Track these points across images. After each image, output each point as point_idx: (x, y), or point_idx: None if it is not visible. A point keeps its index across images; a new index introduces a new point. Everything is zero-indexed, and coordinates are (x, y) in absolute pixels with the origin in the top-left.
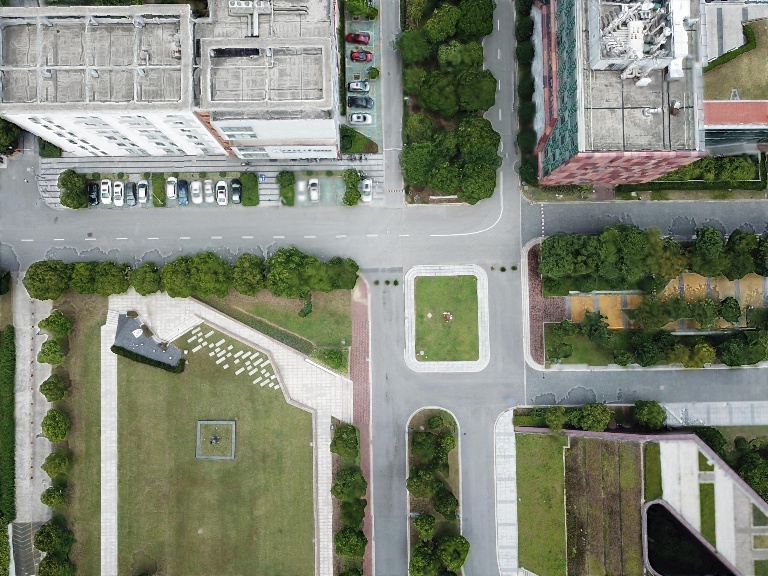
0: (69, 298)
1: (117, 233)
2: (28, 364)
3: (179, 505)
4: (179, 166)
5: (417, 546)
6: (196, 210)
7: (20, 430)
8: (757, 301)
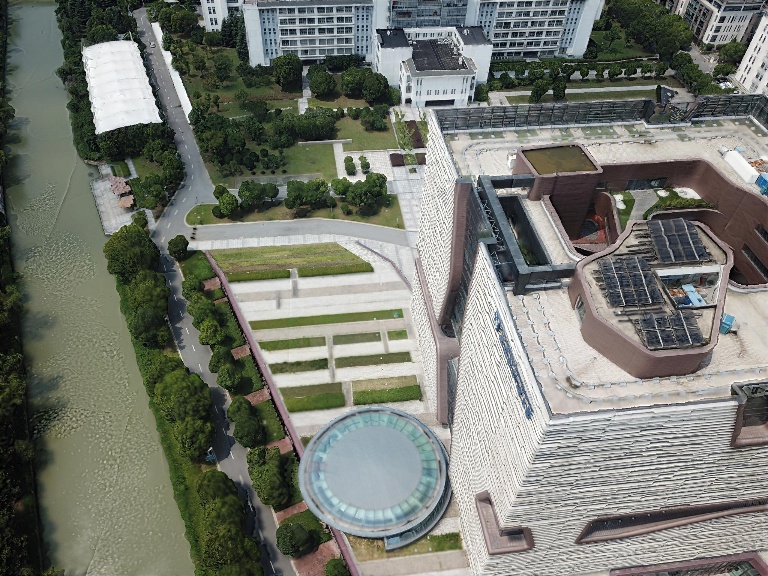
0: None
1: None
2: None
3: None
4: None
5: None
6: None
7: None
8: None
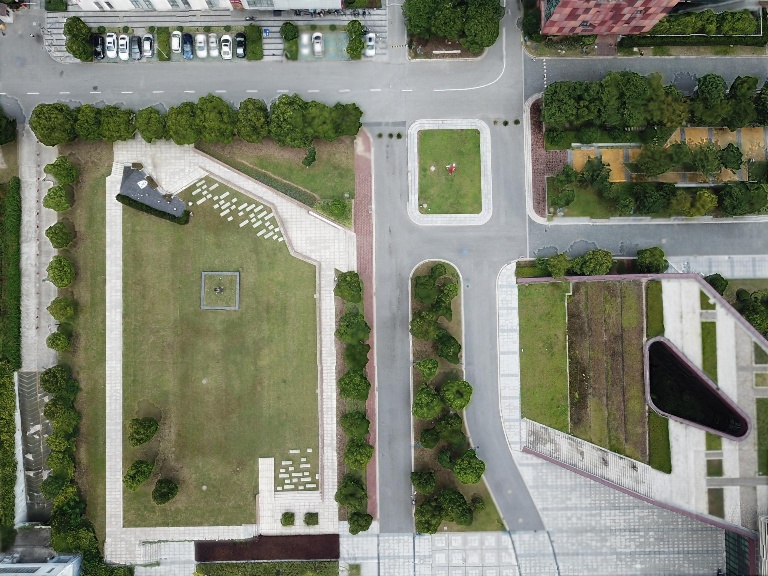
0: (74, 150)
1: (122, 87)
2: (34, 215)
3: (183, 355)
4: (184, 21)
5: (420, 388)
6: (201, 64)
7: (26, 281)
8: (759, 155)
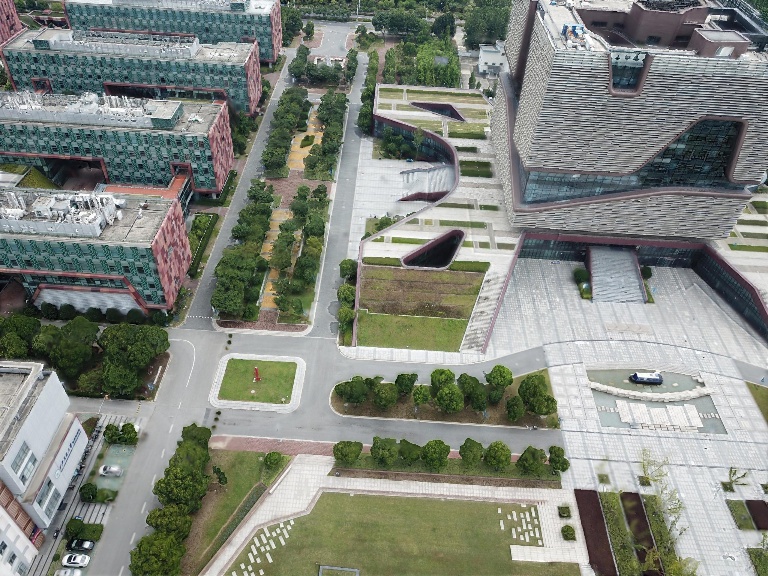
0: None
1: None
2: None
3: None
4: None
5: (438, 402)
6: None
7: None
8: None
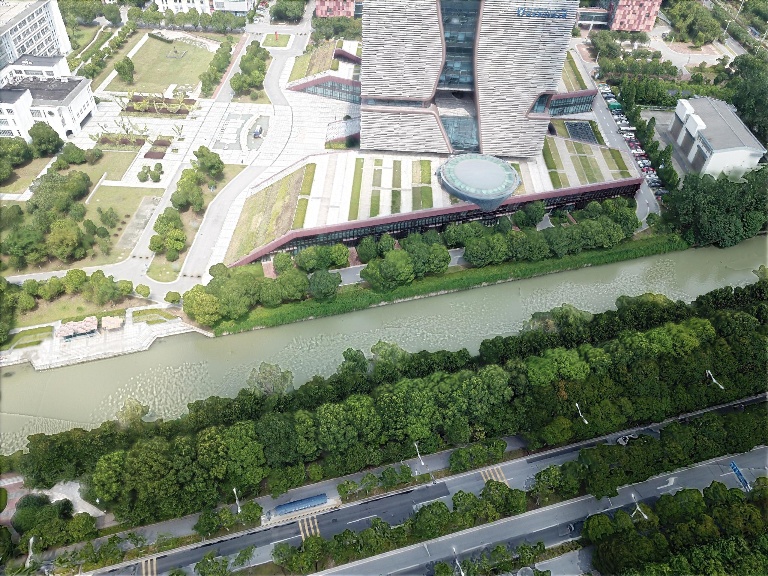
0: (138, 30)
1: None
2: None
3: None
4: None
5: None
6: None
7: None
8: None
